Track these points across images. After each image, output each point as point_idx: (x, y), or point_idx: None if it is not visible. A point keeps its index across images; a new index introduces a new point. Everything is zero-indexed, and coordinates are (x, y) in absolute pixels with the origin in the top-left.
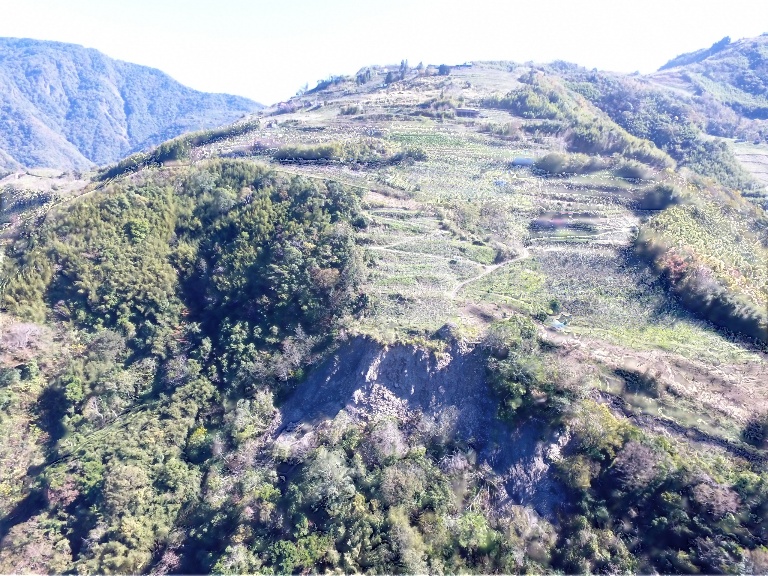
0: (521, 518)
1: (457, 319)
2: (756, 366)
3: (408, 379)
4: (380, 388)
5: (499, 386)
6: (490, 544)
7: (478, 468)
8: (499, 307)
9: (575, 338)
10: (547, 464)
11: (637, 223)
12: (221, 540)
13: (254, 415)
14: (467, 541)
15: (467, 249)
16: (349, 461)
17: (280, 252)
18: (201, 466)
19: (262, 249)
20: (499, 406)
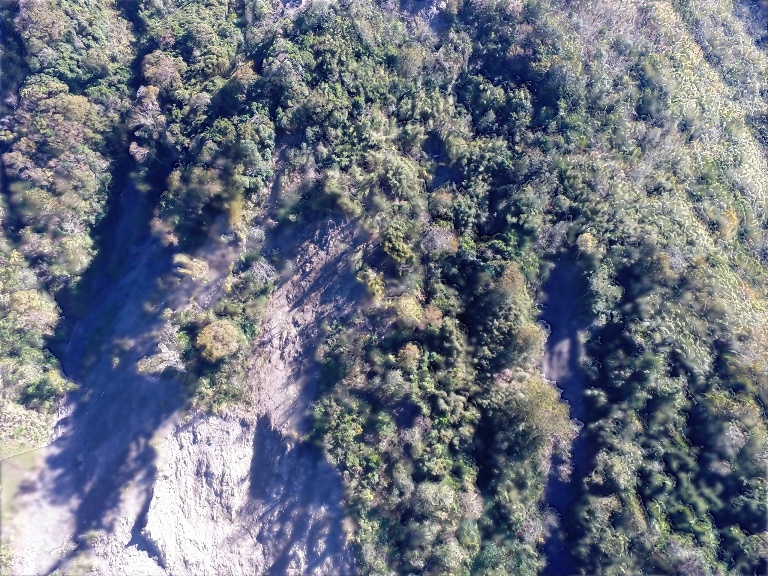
0: None
1: None
2: None
3: None
4: None
5: None
6: (405, 40)
7: (401, 13)
8: None
9: None
10: (438, 11)
11: None
12: None
13: (266, 0)
14: (393, 33)
15: None
16: None
17: None
18: (241, 29)
19: None
20: None
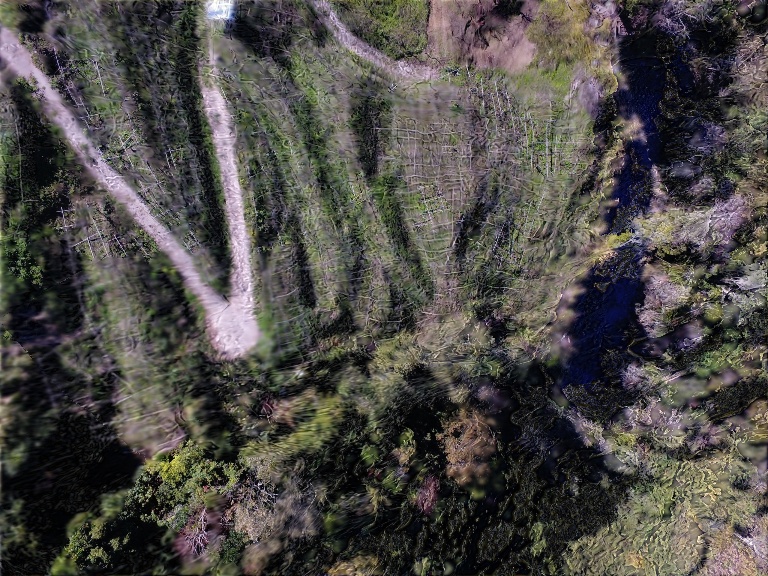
0: None
1: None
2: None
3: None
4: None
5: None
6: None
7: None
8: None
9: None
10: None
11: None
12: None
13: None
14: None
15: (158, 1)
16: None
17: None
18: None
19: None
20: None
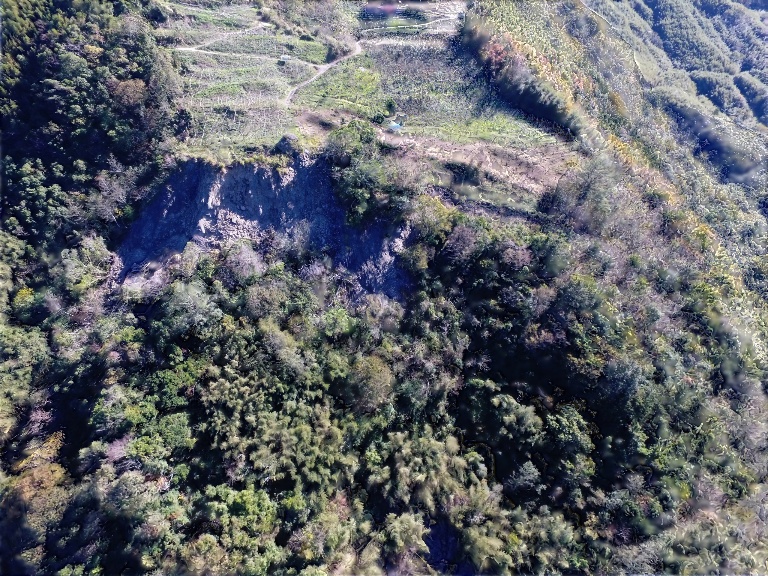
0: (375, 303)
1: (295, 130)
2: (552, 147)
3: (254, 200)
4: (226, 213)
5: (345, 194)
6: (352, 329)
7: (334, 271)
8: (336, 112)
9: (410, 138)
10: (393, 256)
11: (464, 8)
12: (93, 386)
13: (87, 264)
14: (332, 331)
15: (294, 46)
16: (209, 288)
17: (54, 61)
18: (41, 326)
19: (25, 57)
20: (347, 213)
